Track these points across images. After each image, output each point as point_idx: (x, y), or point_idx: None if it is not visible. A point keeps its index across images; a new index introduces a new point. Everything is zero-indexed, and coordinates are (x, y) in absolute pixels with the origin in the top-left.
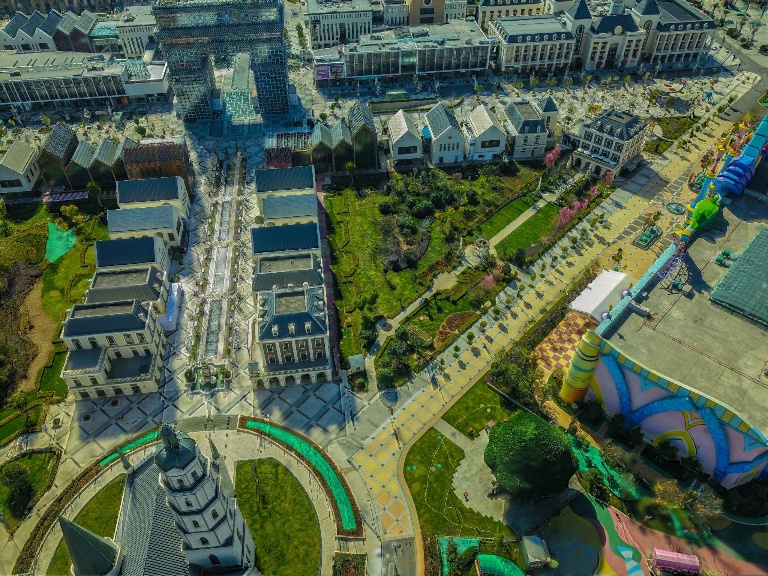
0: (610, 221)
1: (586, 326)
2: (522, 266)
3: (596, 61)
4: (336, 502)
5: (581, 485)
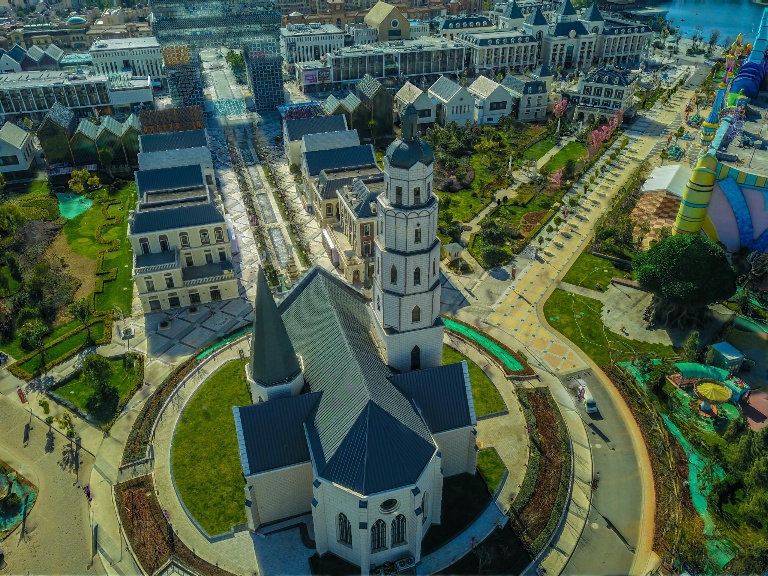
0: (633, 148)
1: (659, 209)
2: (574, 178)
3: (557, 63)
4: (490, 352)
5: (732, 310)
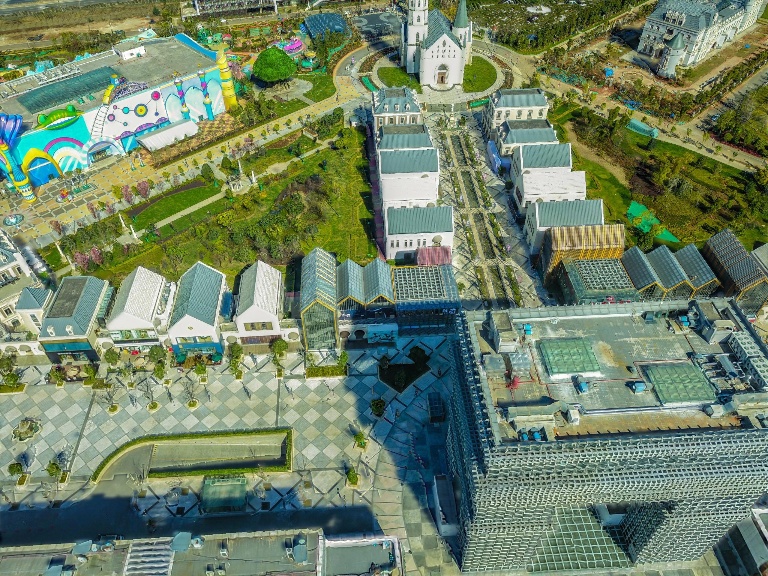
0: None
1: (193, 137)
2: None
3: None
4: None
5: None
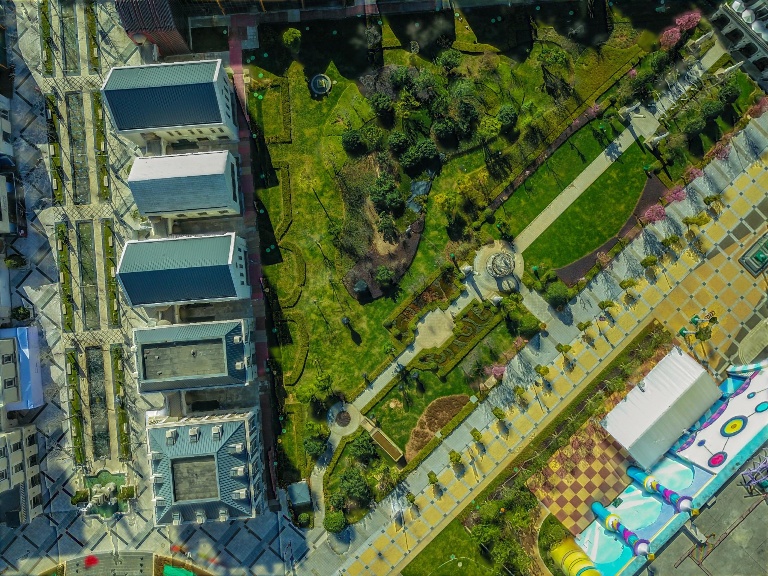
0: (724, 199)
1: None
2: (556, 307)
3: None
4: None
5: None
